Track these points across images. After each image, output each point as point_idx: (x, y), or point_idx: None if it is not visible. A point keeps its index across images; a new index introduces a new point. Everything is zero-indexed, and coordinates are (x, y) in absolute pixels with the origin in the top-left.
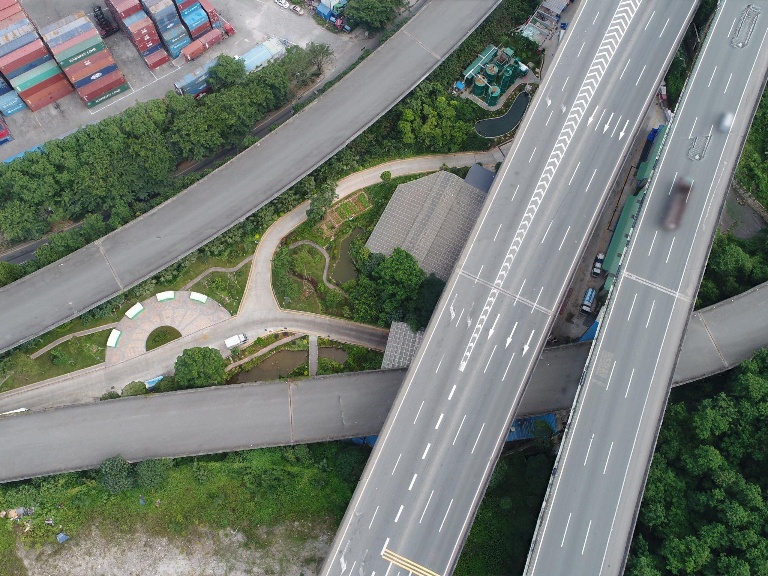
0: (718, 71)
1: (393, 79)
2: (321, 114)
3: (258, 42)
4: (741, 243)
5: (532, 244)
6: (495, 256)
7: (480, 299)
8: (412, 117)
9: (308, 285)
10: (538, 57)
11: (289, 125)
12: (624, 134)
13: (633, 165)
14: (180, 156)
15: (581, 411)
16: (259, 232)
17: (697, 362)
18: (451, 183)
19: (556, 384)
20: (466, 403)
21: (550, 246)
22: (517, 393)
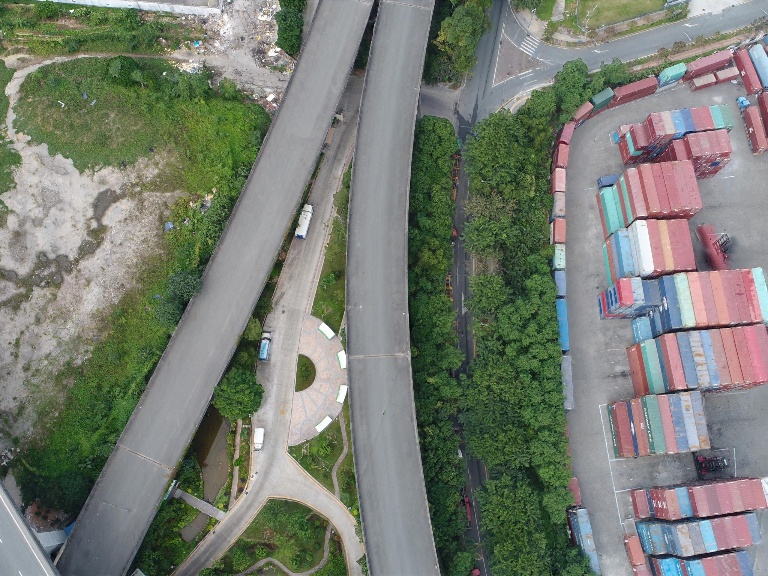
0: None
1: None
2: None
3: None
4: None
5: None
6: None
7: None
8: None
9: None
10: None
11: None
12: None
13: None
14: None
15: None
16: None
17: None
18: None
19: None
20: None
21: None
22: None
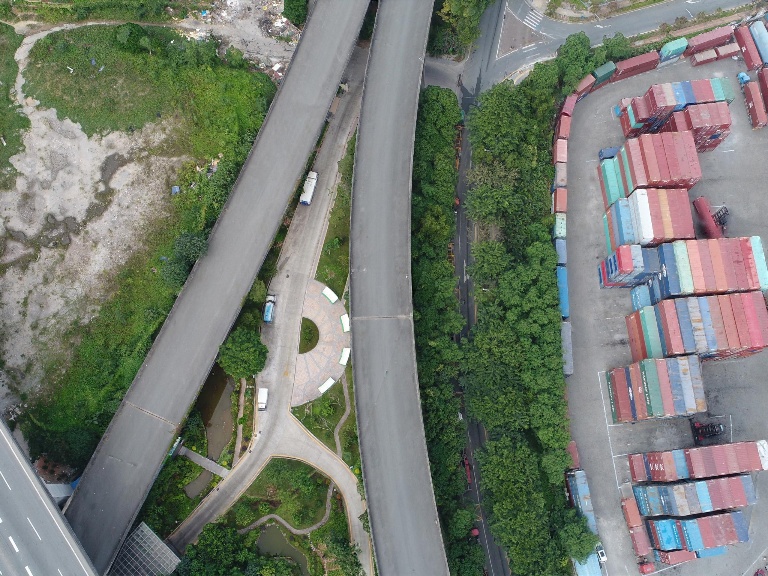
0: None
1: None
2: None
3: None
4: None
5: None
6: None
7: None
8: None
9: None
10: None
11: (445, 568)
12: None
13: None
14: None
15: None
16: None
17: None
18: None
19: None
20: None
21: None
22: None
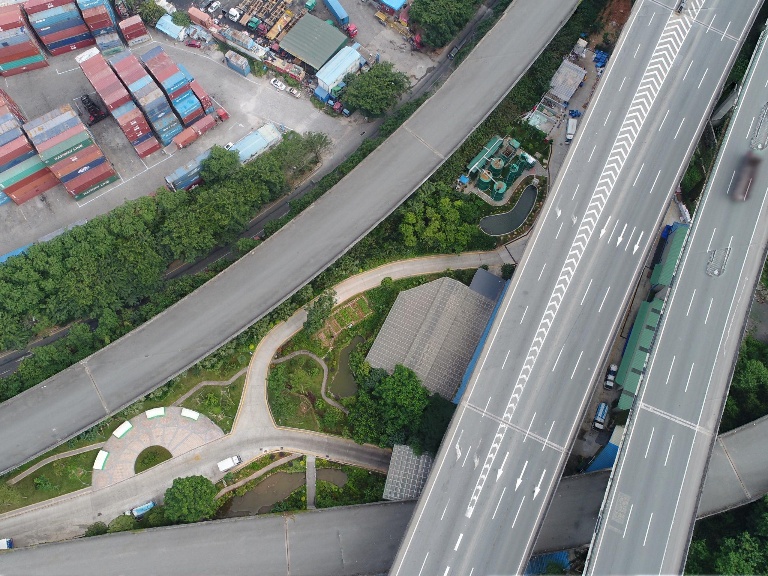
0: (737, 176)
1: (394, 180)
2: (318, 219)
3: (253, 127)
4: (761, 348)
5: (542, 372)
6: (503, 386)
7: (488, 435)
8: (414, 220)
9: (305, 401)
10: (546, 147)
11: (285, 231)
12: (638, 247)
13: (646, 265)
14: (171, 257)
15: (596, 562)
16: (254, 342)
17: (718, 493)
18: (455, 291)
19: (568, 518)
20: (473, 554)
21: (561, 374)
22: (528, 542)
